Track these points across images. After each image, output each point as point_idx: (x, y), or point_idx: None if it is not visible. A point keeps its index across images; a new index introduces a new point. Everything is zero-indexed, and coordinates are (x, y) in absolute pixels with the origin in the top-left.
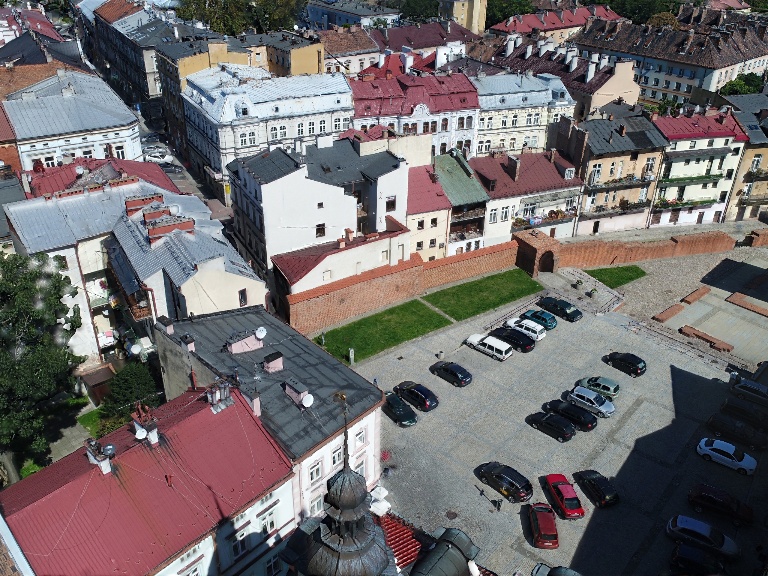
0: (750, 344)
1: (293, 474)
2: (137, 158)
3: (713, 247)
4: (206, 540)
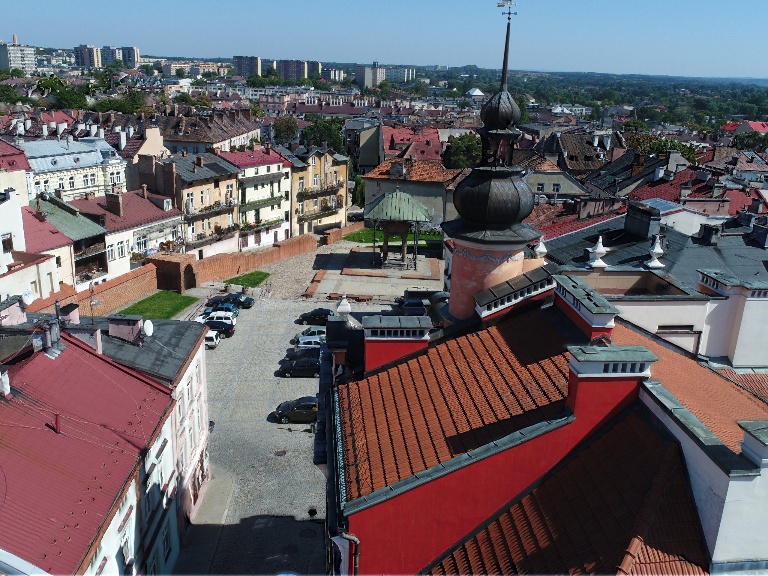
0: (380, 293)
1: (174, 401)
2: None
3: (304, 248)
4: (132, 482)
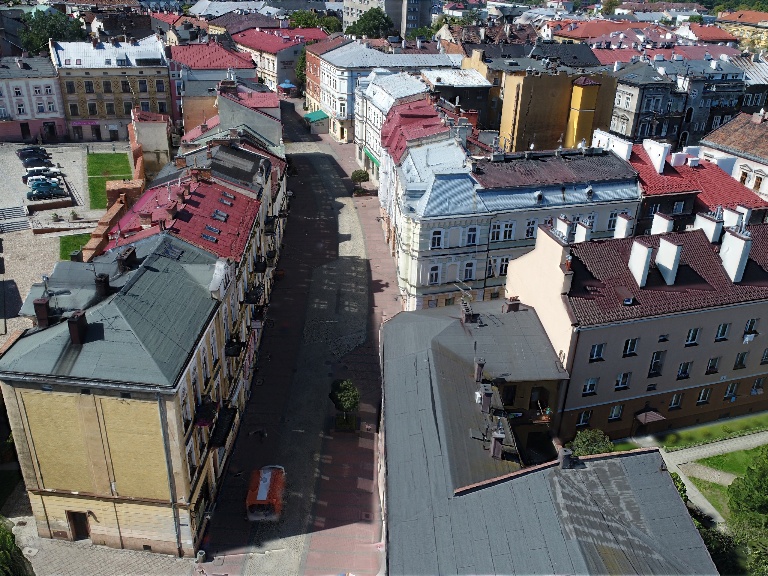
0: None
1: None
2: (343, 94)
3: None
4: None
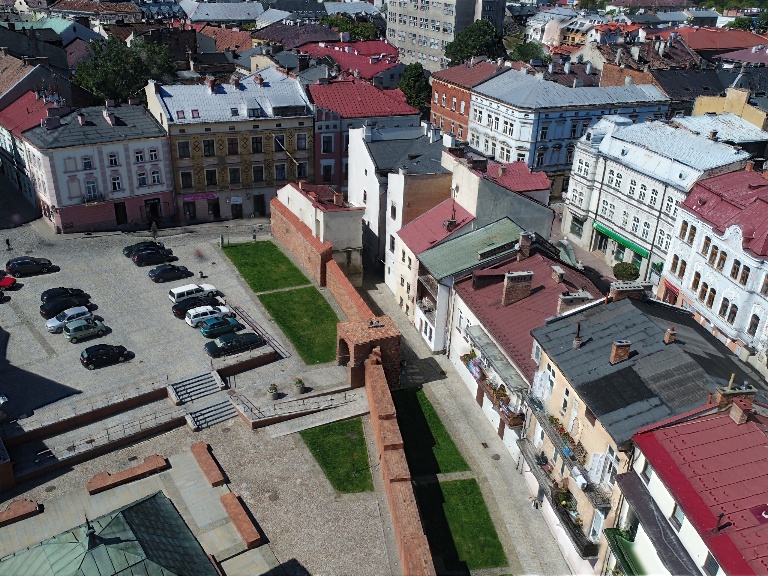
0: None
1: (21, 141)
2: (523, 142)
3: None
4: None
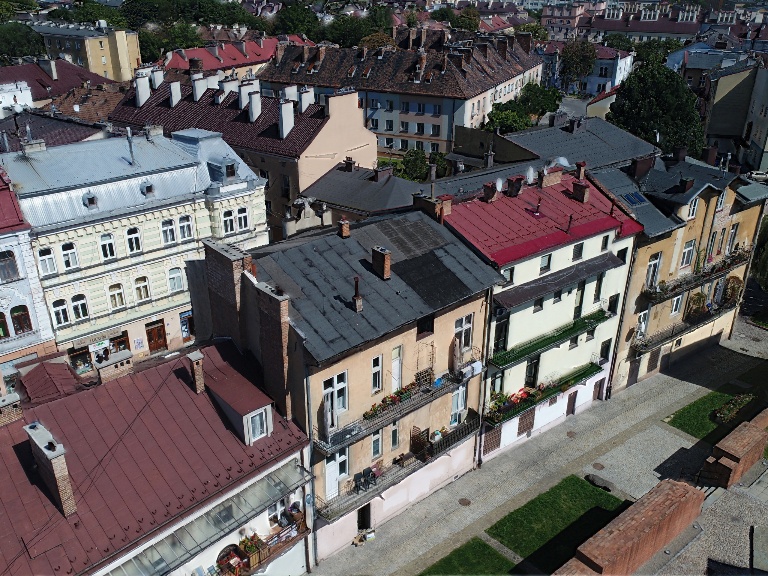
0: None
1: None
2: None
3: (667, 532)
4: None
